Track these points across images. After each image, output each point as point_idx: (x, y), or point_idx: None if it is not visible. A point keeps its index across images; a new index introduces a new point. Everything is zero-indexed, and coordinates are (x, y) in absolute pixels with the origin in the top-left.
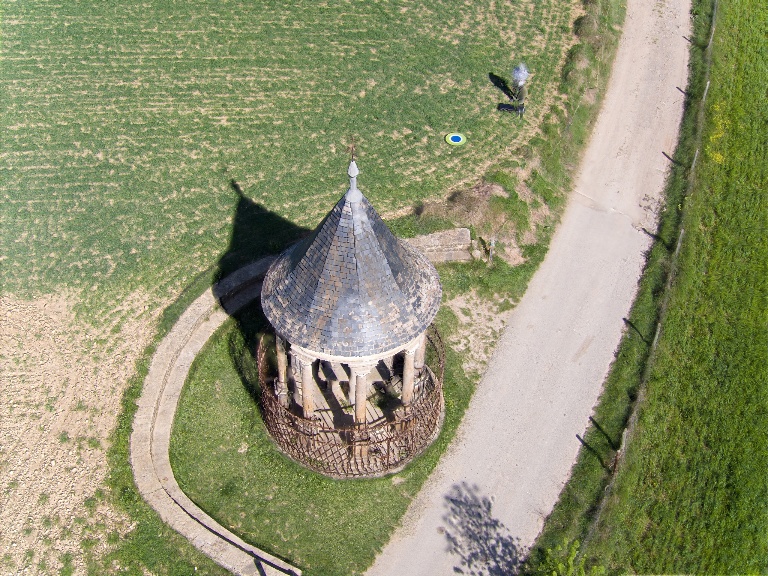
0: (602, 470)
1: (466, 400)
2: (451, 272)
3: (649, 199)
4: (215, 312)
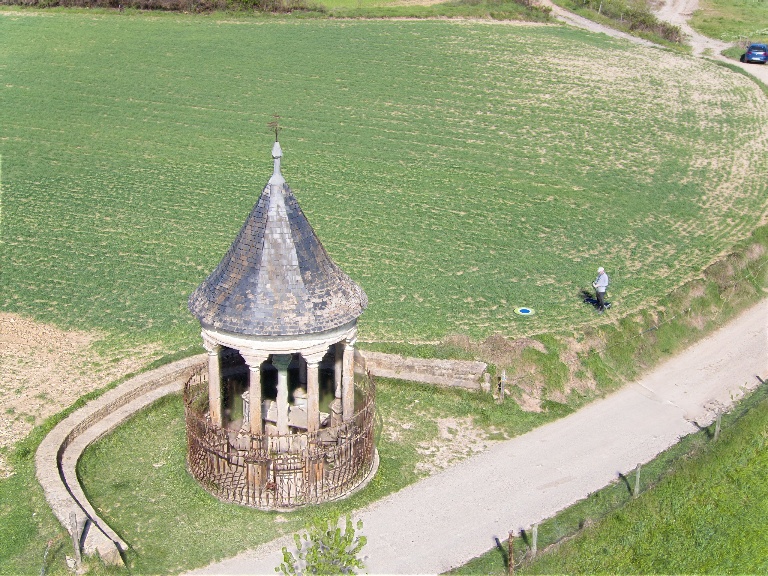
0: (502, 568)
1: (399, 485)
2: (456, 399)
3: (718, 404)
4: None
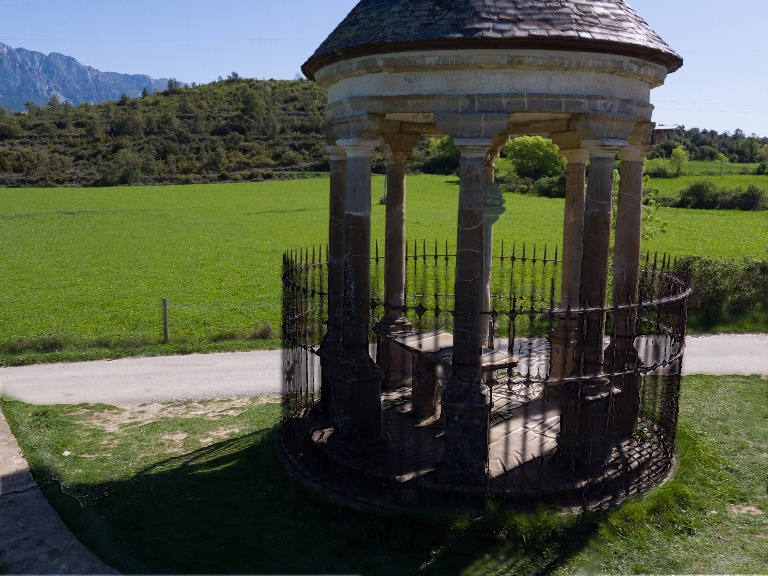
0: None
1: None
2: None
3: None
4: None
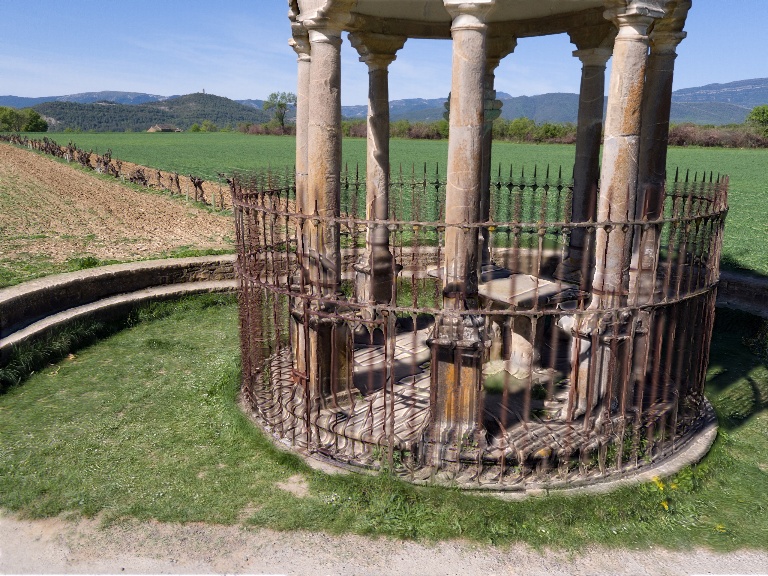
0: None
1: (743, 542)
2: None
3: None
4: None
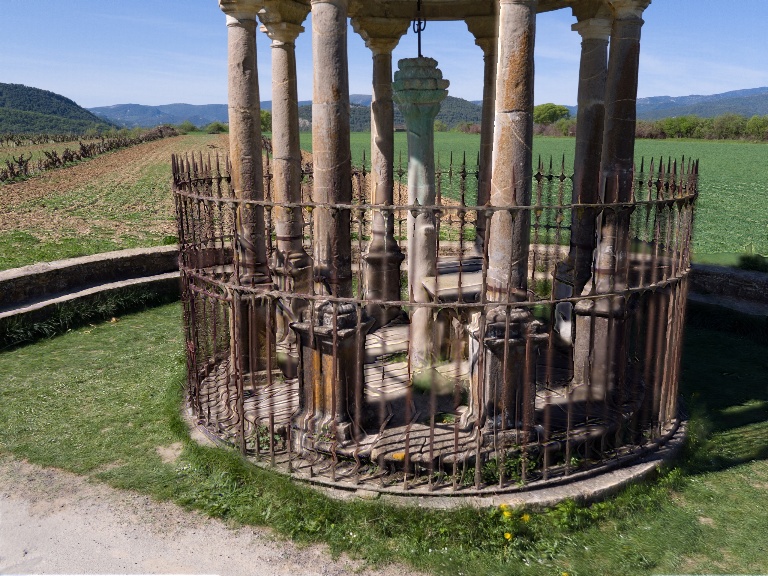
0: None
1: None
2: None
3: None
4: None
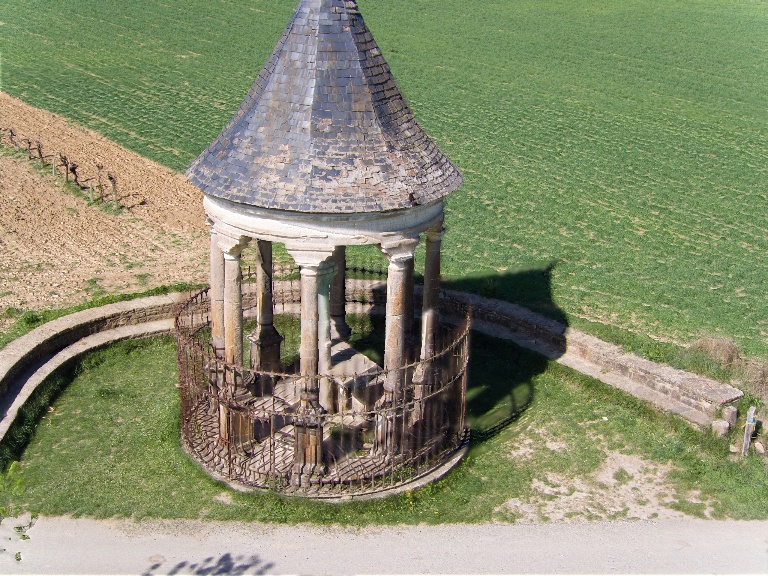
0: None
1: (445, 517)
2: (669, 434)
3: None
4: (359, 303)
